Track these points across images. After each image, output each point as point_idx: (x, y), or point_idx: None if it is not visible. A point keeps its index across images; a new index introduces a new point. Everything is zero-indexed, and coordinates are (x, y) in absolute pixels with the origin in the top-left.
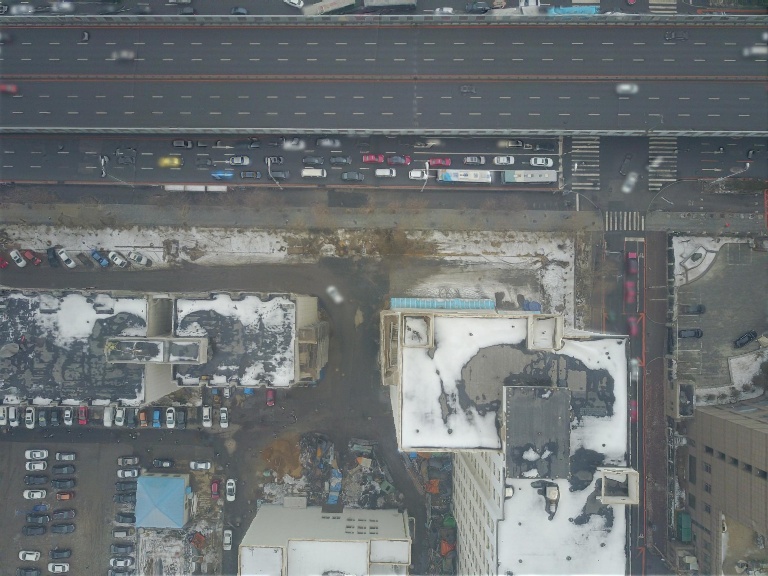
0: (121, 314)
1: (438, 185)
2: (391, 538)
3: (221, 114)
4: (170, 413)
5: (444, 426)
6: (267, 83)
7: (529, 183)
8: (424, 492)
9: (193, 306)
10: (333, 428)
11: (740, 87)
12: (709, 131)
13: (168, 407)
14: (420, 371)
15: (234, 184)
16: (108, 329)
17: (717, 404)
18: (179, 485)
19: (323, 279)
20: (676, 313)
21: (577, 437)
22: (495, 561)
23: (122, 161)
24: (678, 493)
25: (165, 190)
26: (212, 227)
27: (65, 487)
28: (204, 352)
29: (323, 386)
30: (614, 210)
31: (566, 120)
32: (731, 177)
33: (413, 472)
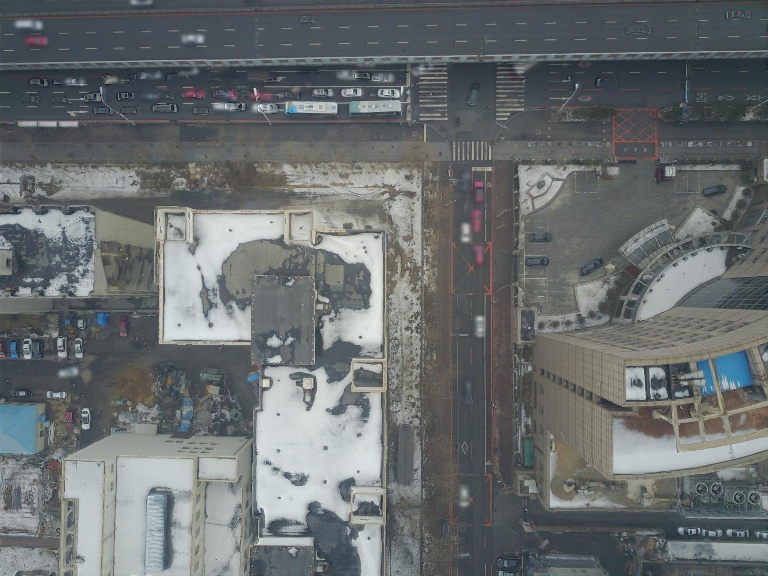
0: None
1: (288, 118)
2: (218, 455)
3: (69, 50)
4: (26, 344)
5: (205, 320)
6: (113, 18)
7: (376, 114)
8: None
9: None
10: (185, 358)
11: (576, 11)
12: (541, 54)
13: (25, 338)
14: (182, 267)
15: (88, 121)
16: None
17: (562, 331)
18: (31, 412)
19: None
20: (522, 241)
21: (334, 330)
22: None
23: None
24: (524, 420)
25: (21, 127)
26: (66, 163)
27: None
28: (3, 262)
29: None
30: (461, 140)
31: (405, 48)
32: (579, 105)
33: None
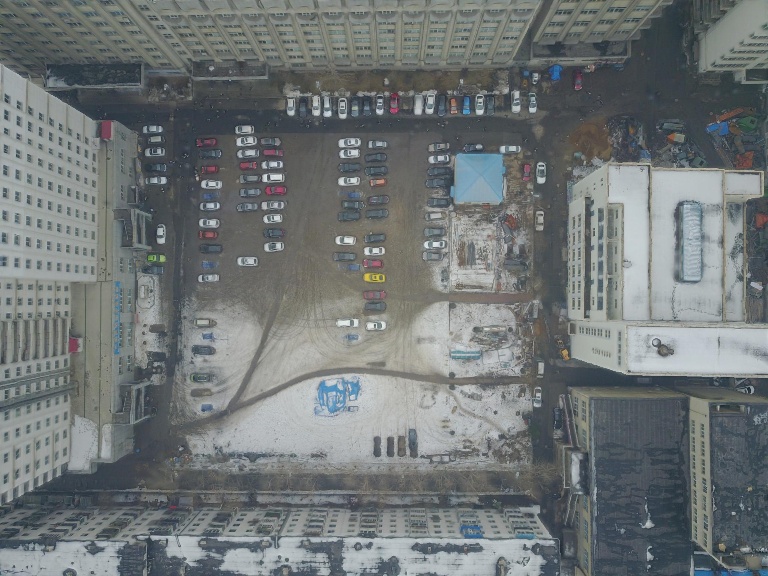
0: None
1: None
2: (743, 170)
3: None
4: (480, 98)
5: None
6: None
7: None
8: None
9: None
10: (640, 111)
11: None
12: None
13: (477, 94)
14: None
15: None
16: None
17: None
18: (499, 159)
19: None
20: None
21: None
22: None
23: None
24: None
25: None
26: None
27: (378, 173)
28: None
29: (629, 70)
30: None
31: None
32: None
33: (723, 151)
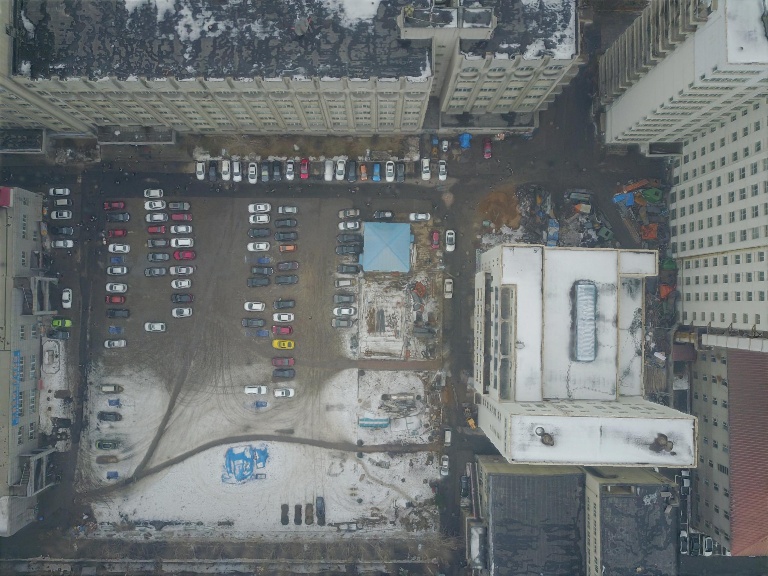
0: None
1: None
2: None
3: None
4: (390, 165)
5: (767, 43)
6: None
7: None
8: (640, 240)
9: None
10: (549, 180)
11: None
12: None
13: (387, 161)
14: None
15: None
16: (392, 10)
17: None
18: (406, 228)
19: None
20: None
21: None
22: None
23: None
24: None
25: None
26: None
27: (288, 239)
28: (495, 20)
29: (538, 139)
30: None
31: None
32: None
33: (629, 220)
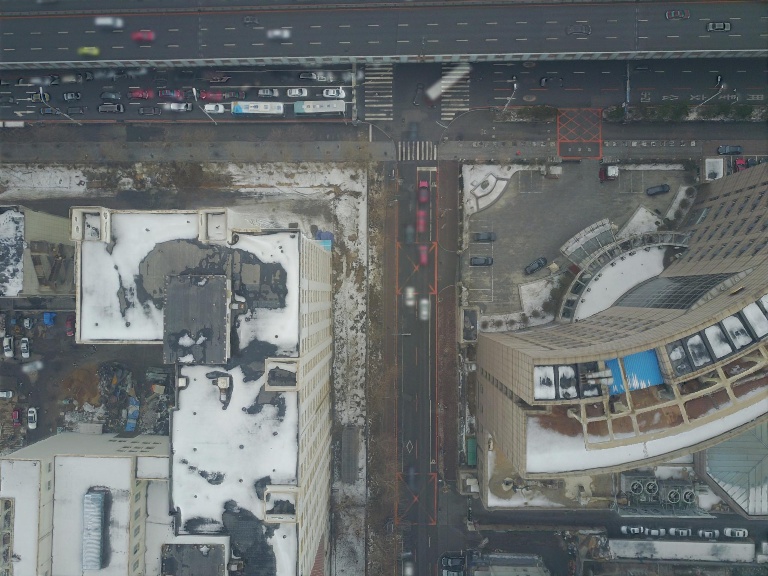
0: None
1: (234, 118)
2: (156, 454)
3: (15, 50)
4: None
5: (122, 319)
6: (58, 19)
7: (321, 114)
8: None
9: None
10: (131, 357)
11: (517, 11)
12: (481, 54)
13: None
14: (99, 266)
15: (35, 121)
16: None
17: (506, 330)
18: None
19: None
20: (466, 241)
21: (251, 329)
22: None
23: None
24: (469, 419)
25: None
26: (13, 163)
27: None
28: None
29: None
30: (406, 140)
31: (347, 48)
32: (523, 105)
33: None
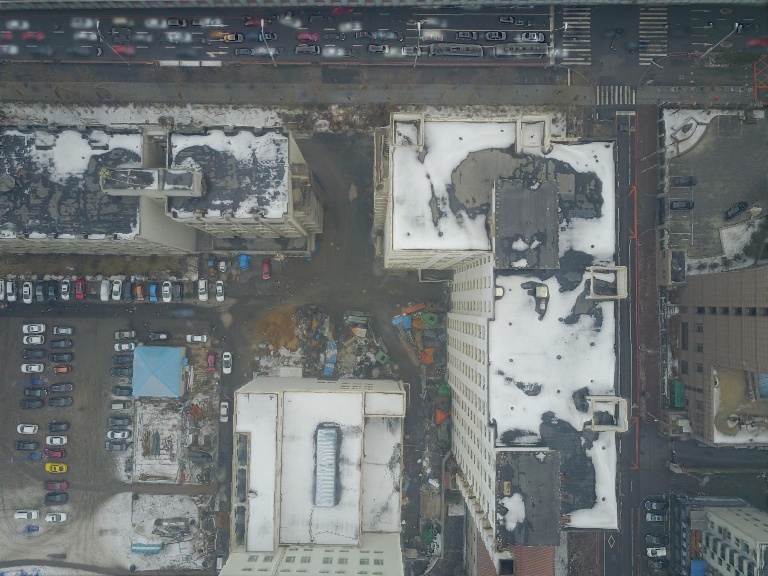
0: (116, 150)
1: (431, 61)
2: (386, 390)
3: None
4: (166, 286)
5: (435, 229)
6: None
7: (521, 58)
8: (419, 363)
9: (187, 141)
10: (328, 301)
11: None
12: None
13: (164, 281)
14: (411, 175)
15: (228, 62)
16: (103, 165)
17: None
18: (176, 354)
19: (317, 154)
20: (667, 184)
21: (566, 239)
22: (486, 359)
23: (117, 40)
24: (671, 362)
25: (160, 67)
26: (207, 103)
27: (63, 361)
28: (198, 181)
29: (318, 260)
30: (605, 84)
31: None
32: (721, 51)
33: (408, 343)
